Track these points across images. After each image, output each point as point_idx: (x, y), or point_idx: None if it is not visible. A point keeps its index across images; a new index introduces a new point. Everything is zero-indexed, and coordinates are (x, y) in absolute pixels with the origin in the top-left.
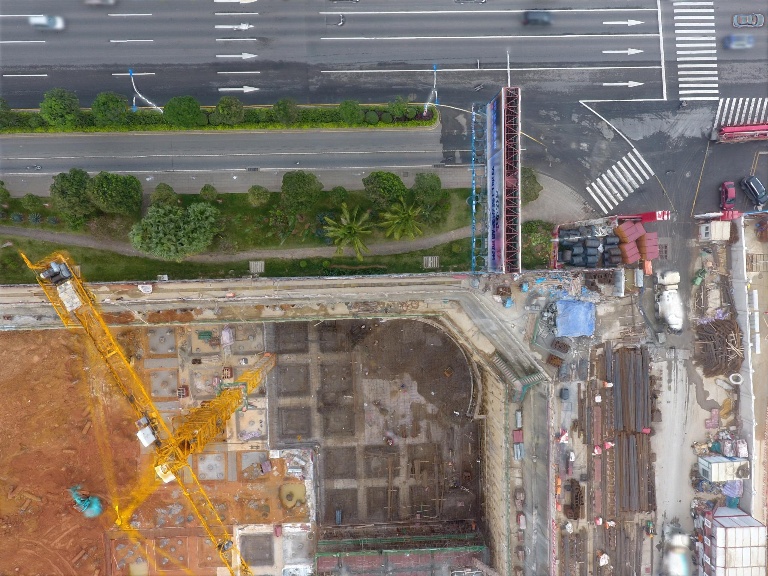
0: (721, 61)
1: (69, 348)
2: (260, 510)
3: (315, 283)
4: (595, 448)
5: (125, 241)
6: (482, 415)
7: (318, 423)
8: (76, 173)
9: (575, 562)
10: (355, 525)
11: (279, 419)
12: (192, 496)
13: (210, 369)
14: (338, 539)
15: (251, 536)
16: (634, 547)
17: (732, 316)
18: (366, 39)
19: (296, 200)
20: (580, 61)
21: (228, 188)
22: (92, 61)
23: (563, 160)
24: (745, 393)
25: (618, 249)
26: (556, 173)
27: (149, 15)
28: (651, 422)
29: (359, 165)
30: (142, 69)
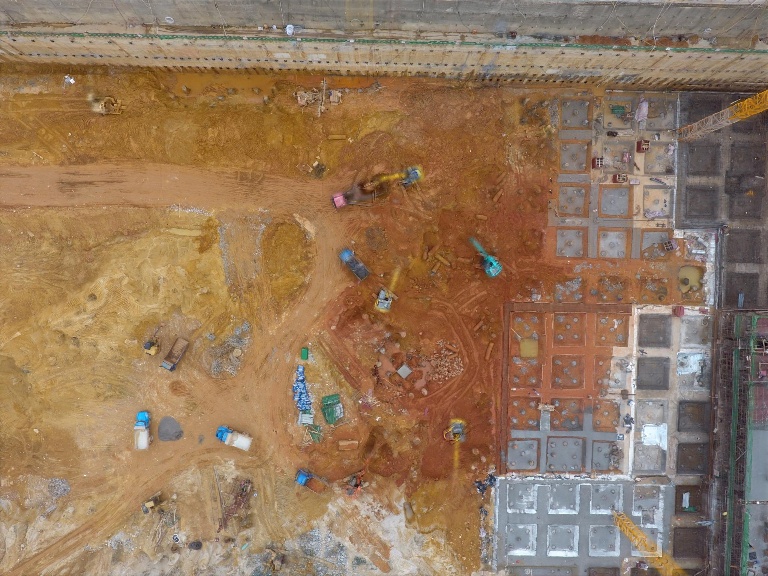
0: None
1: None
2: (657, 292)
3: None
4: None
5: None
6: None
7: (725, 204)
8: None
9: None
10: (757, 310)
11: (685, 199)
12: (594, 272)
13: (619, 145)
14: (755, 314)
15: (647, 318)
16: None
17: None
18: None
19: None
20: None
21: None
22: None
23: None
24: None
25: None
26: None
27: None
28: None
29: None
30: None
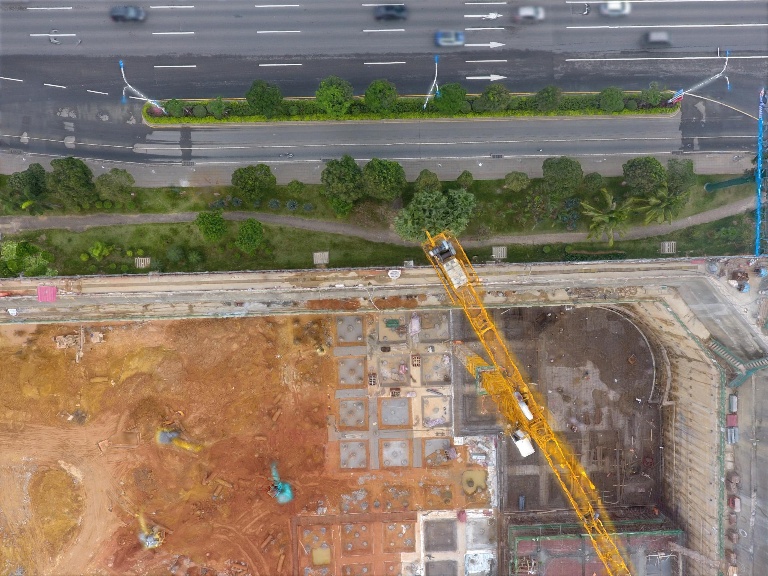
0: None
1: (265, 336)
2: (442, 496)
3: (557, 268)
4: None
5: (373, 227)
6: (671, 401)
7: None
8: (348, 160)
9: None
10: (538, 511)
11: (463, 406)
12: (378, 482)
13: (396, 357)
14: (528, 524)
15: (433, 522)
16: None
17: None
18: (610, 28)
19: (562, 185)
20: None
21: (473, 175)
22: (345, 50)
23: None
24: None
25: None
26: None
27: (401, 5)
28: None
29: (600, 152)
30: (393, 58)
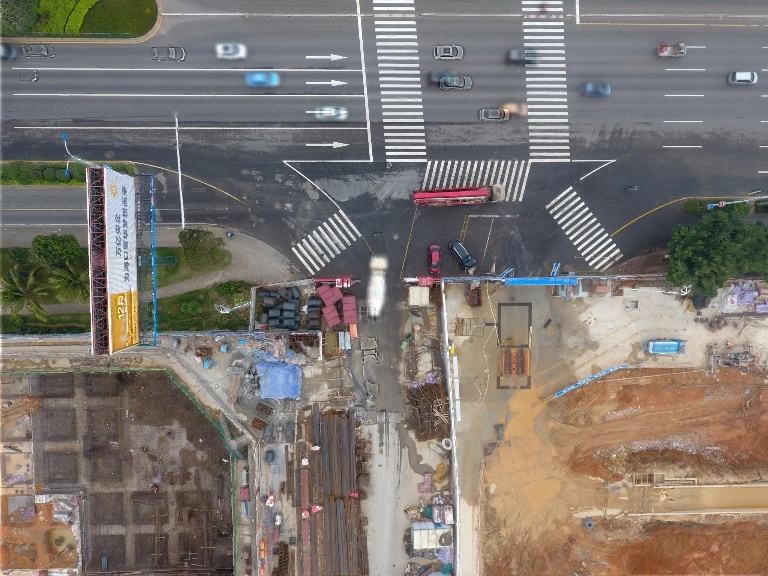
0: (428, 123)
1: None
2: (27, 555)
3: (9, 341)
4: (303, 511)
5: None
6: None
7: (84, 468)
8: None
9: None
10: (121, 572)
11: (45, 463)
12: None
13: None
14: None
15: None
16: None
17: (442, 380)
18: (61, 95)
19: None
20: (282, 121)
21: None
22: None
23: (267, 220)
24: (453, 459)
25: (315, 313)
26: (260, 233)
27: None
28: (361, 486)
29: (55, 222)
30: None
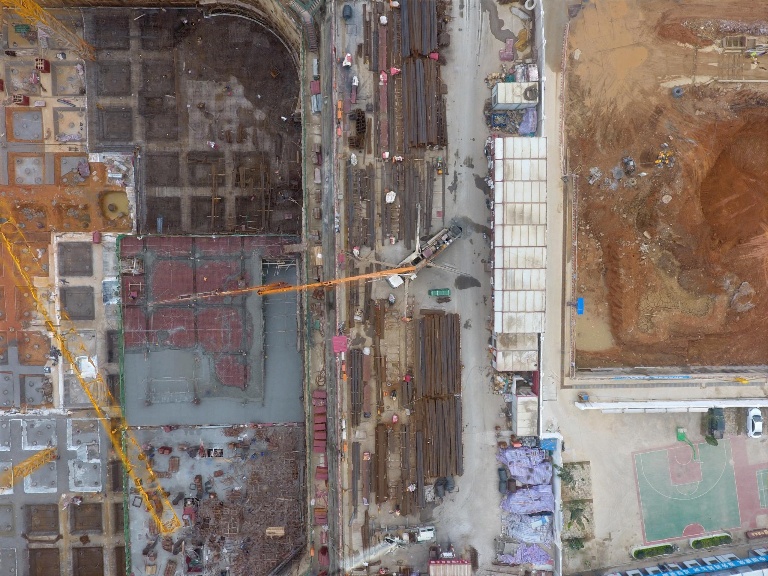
0: None
1: None
2: (80, 219)
3: None
4: (380, 74)
5: None
6: None
7: (139, 125)
8: None
9: (359, 197)
10: None
11: (99, 121)
12: (7, 199)
13: (28, 66)
14: None
15: (70, 246)
16: (424, 188)
17: None
18: None
19: None
20: None
21: None
22: None
23: None
24: (537, 15)
25: None
26: None
27: None
28: (441, 50)
29: None
30: None
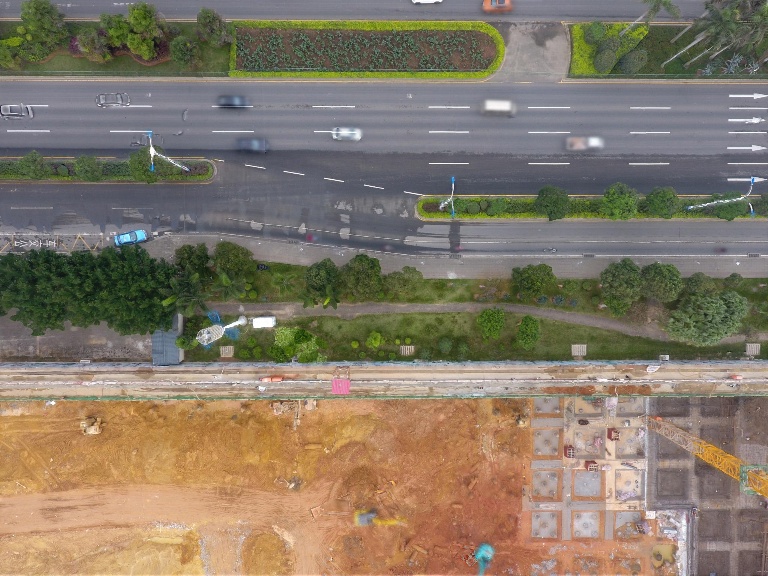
0: None
1: (469, 407)
2: (631, 569)
3: None
4: None
5: None
6: None
7: (695, 486)
8: (630, 263)
9: None
10: None
11: (656, 480)
12: (569, 553)
13: (591, 429)
14: None
15: None
16: None
17: None
18: None
19: None
20: None
21: (731, 273)
22: (612, 151)
23: None
24: None
25: None
26: None
27: (667, 108)
28: None
29: None
30: (657, 159)
